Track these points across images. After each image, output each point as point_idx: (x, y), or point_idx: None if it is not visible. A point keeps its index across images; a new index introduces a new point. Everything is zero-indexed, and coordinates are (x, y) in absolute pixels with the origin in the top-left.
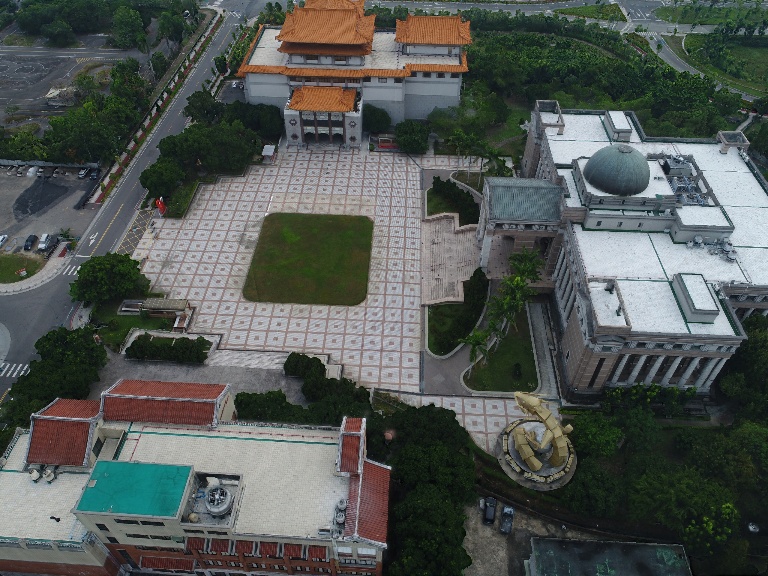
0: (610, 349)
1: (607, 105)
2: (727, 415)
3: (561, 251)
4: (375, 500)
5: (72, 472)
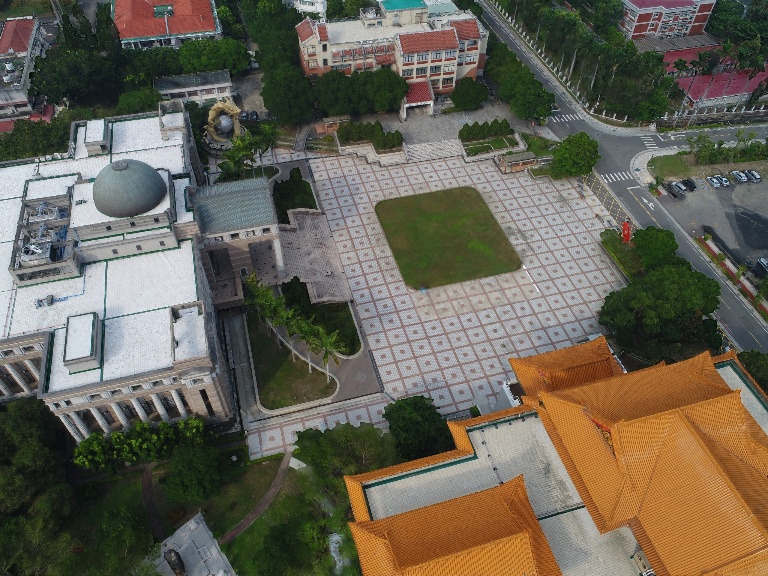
0: None
1: None
2: None
3: None
4: None
5: None
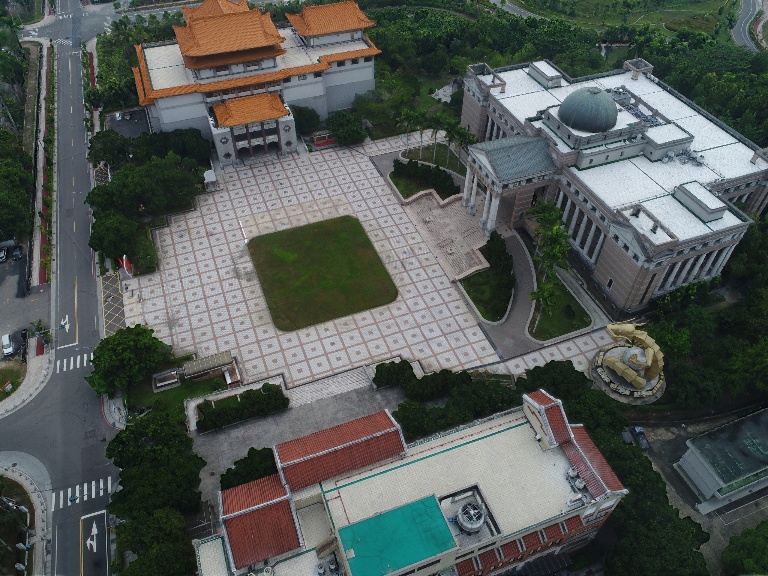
0: (661, 264)
1: (503, 60)
2: (734, 291)
3: (560, 195)
4: (594, 456)
5: (286, 559)
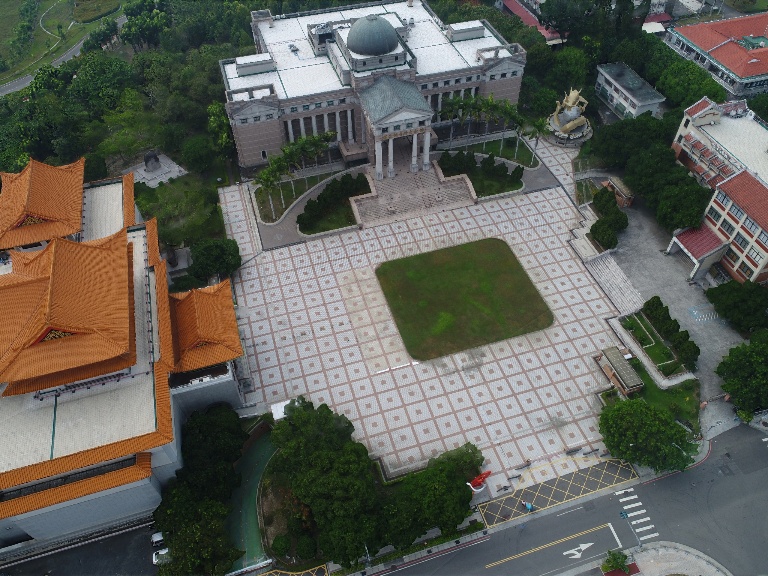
0: None
1: None
2: None
3: None
4: None
5: None
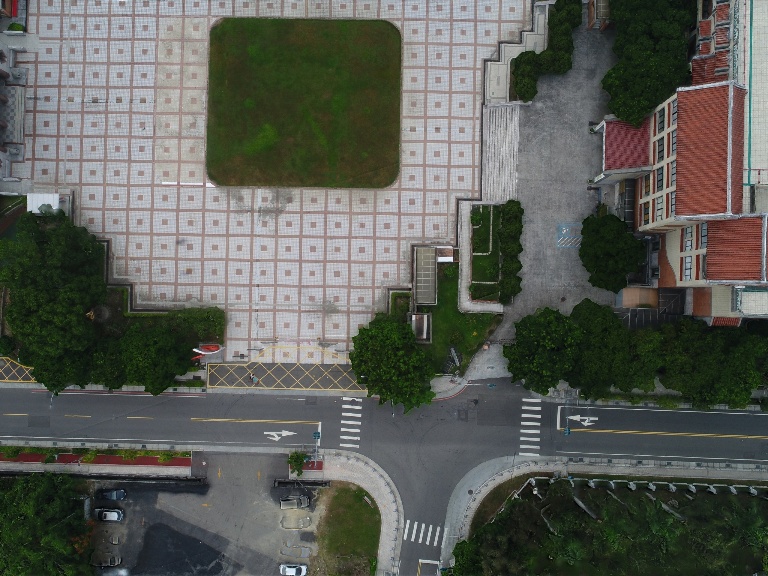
0: None
1: None
2: None
3: None
4: None
5: None
